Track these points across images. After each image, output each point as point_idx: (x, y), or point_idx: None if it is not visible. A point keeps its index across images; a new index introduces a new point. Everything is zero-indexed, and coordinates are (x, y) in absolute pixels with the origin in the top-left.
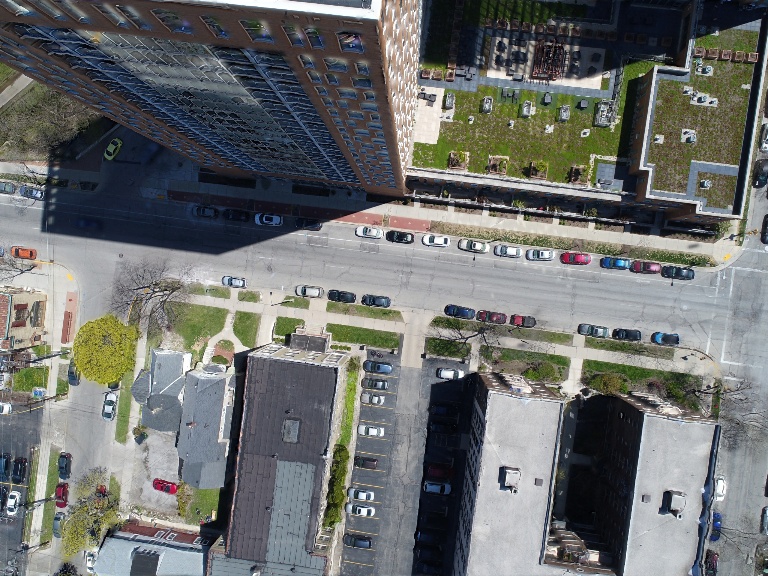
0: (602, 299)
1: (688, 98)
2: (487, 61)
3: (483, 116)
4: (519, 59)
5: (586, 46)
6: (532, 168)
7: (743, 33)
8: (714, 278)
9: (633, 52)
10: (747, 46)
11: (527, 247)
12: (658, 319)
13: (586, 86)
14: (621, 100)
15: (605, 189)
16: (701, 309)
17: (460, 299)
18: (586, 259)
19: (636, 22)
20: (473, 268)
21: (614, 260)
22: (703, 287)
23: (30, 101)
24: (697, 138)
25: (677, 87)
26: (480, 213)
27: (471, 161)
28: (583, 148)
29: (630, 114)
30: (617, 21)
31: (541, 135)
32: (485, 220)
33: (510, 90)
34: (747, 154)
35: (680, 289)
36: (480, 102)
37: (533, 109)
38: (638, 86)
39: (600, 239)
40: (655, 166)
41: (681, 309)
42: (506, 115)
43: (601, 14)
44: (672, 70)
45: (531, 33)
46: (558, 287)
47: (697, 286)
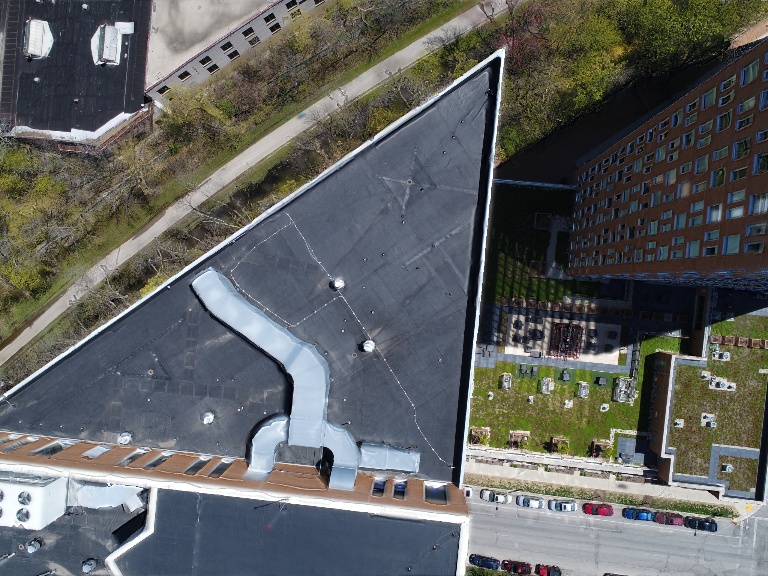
0: (626, 549)
1: (706, 383)
2: (504, 338)
3: (502, 392)
4: (536, 337)
5: (602, 322)
6: (553, 445)
7: (758, 319)
8: (737, 528)
9: (649, 328)
10: (763, 332)
11: (549, 497)
12: (683, 569)
13: (603, 362)
14: (639, 375)
15: (626, 463)
16: (725, 559)
17: (484, 548)
18: (609, 512)
19: (651, 300)
20: (496, 518)
21: (636, 512)
22: (726, 537)
23: (49, 342)
24: (717, 422)
25: (695, 372)
26: (501, 464)
27: (492, 436)
28: (603, 423)
29: (648, 389)
30: (632, 298)
31: (561, 410)
32: (506, 471)
33: (528, 366)
34: (767, 440)
35: (703, 539)
36: (499, 378)
37: (552, 385)
38: (655, 361)
39: (622, 490)
40: (676, 450)
41: (705, 559)
42: (525, 391)
43: (616, 291)
44: (689, 359)
45: (547, 310)
46: (581, 537)
47: (720, 536)
